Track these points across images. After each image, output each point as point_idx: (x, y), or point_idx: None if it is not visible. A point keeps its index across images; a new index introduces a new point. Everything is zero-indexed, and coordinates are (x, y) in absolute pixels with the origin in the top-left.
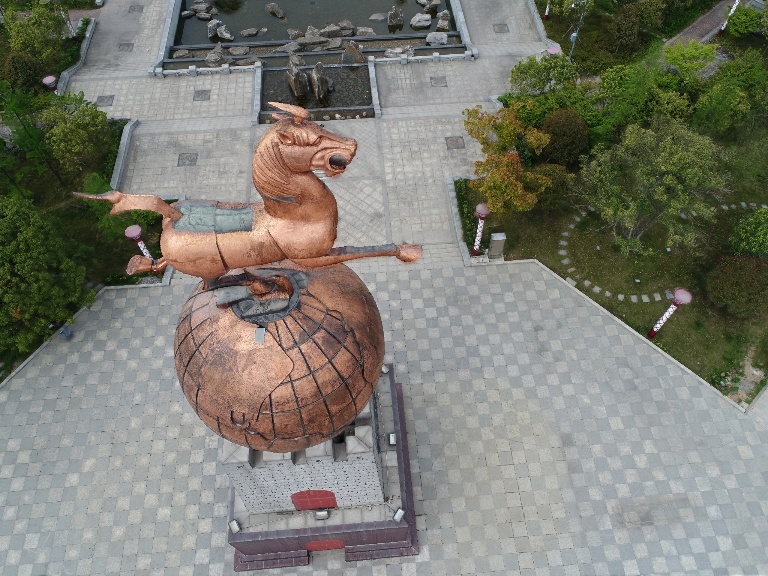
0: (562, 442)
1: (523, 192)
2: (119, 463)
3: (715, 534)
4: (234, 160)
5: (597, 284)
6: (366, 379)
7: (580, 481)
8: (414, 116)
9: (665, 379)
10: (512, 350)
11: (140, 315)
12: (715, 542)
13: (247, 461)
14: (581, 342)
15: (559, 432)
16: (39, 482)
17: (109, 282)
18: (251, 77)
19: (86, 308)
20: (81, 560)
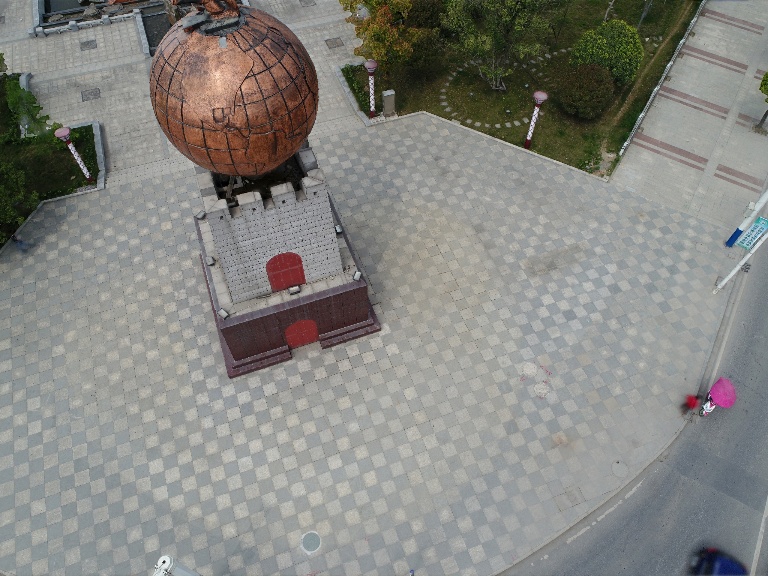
0: (476, 231)
1: (399, 41)
2: (99, 328)
3: (603, 264)
4: (136, 88)
5: (477, 120)
6: (309, 86)
7: (496, 253)
8: (293, 29)
9: (544, 173)
10: (420, 177)
11: (84, 216)
12: (605, 269)
13: (227, 208)
14: (474, 161)
15: (472, 225)
16: (26, 359)
17: (45, 197)
18: (132, 24)
19: (29, 221)
20: (86, 405)
